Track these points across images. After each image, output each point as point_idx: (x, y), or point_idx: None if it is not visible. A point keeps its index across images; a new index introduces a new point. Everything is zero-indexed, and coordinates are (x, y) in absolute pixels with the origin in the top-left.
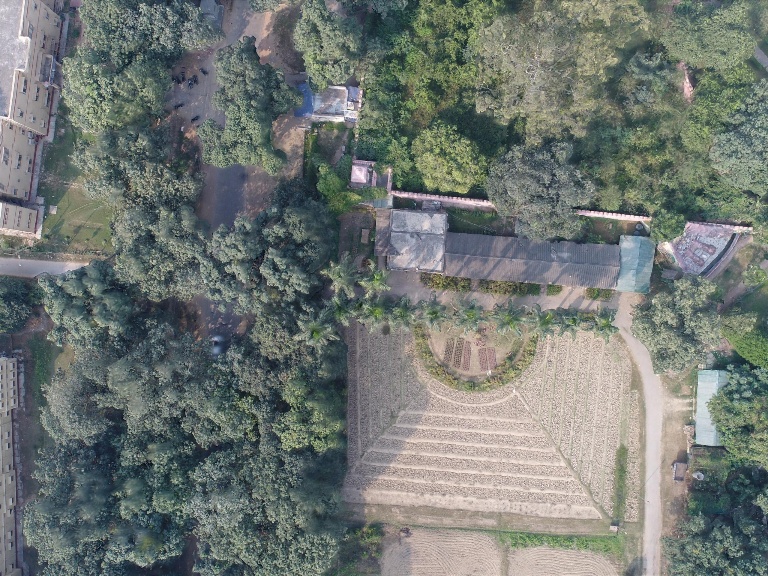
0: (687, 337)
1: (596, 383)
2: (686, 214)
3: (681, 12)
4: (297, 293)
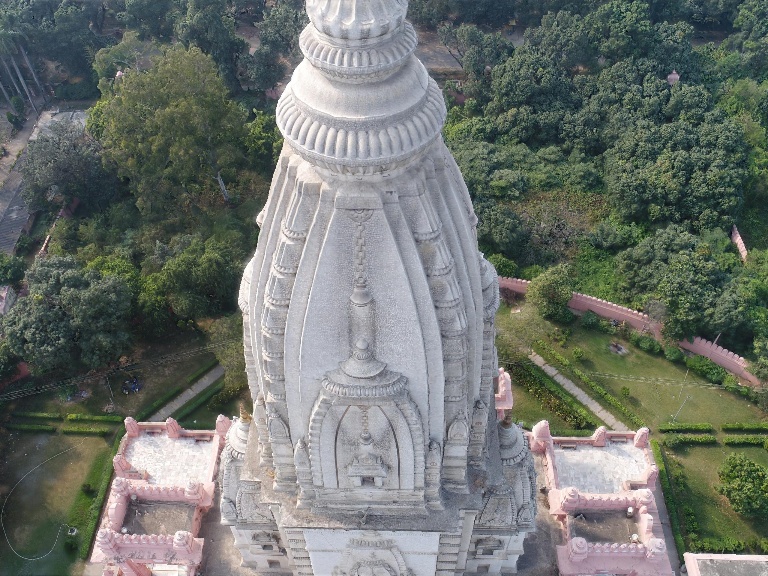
0: None
1: None
2: None
3: None
4: (26, 42)
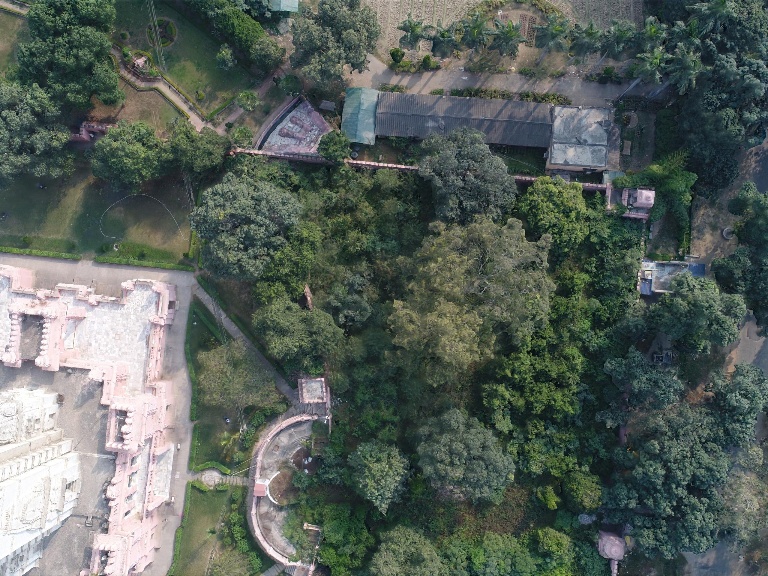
0: (327, 26)
1: (394, 4)
2: (307, 170)
3: (320, 363)
4: None
